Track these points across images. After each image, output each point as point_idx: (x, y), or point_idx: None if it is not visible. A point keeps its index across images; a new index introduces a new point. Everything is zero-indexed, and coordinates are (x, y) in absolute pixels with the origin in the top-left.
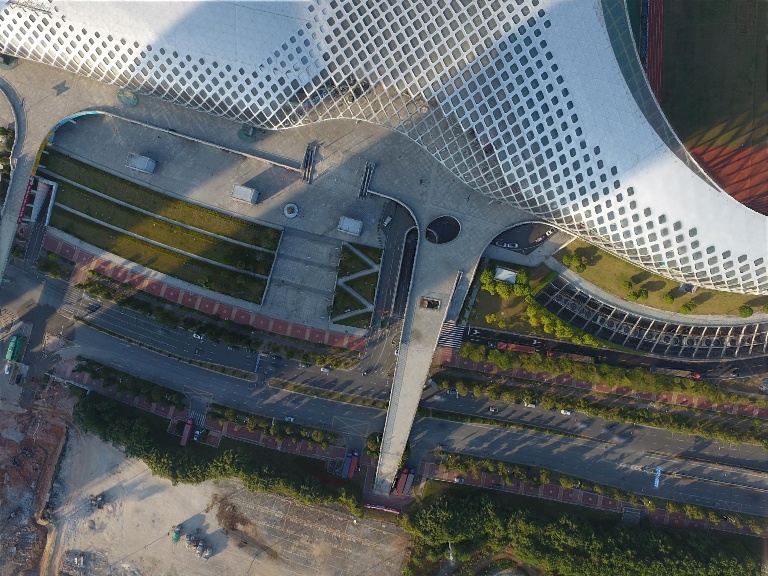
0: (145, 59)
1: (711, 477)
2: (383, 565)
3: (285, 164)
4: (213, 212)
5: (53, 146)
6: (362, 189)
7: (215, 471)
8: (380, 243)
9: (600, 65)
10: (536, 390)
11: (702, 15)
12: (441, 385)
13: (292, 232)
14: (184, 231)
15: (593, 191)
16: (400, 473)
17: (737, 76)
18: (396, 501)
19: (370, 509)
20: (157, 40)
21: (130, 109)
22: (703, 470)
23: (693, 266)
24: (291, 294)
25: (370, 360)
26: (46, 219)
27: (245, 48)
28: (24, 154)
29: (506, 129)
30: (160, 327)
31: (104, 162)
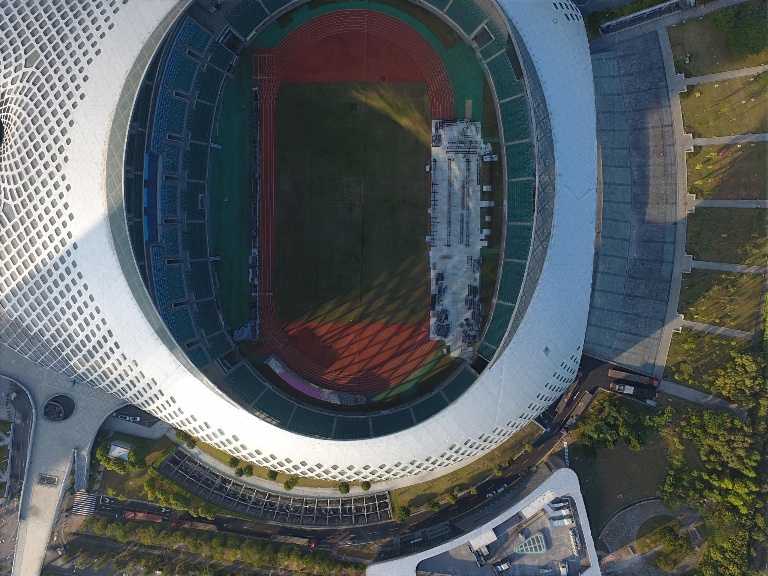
0: None
1: None
2: None
3: None
4: None
5: None
6: None
7: None
8: (8, 417)
9: (118, 289)
10: (166, 556)
11: (311, 194)
12: (62, 558)
13: None
14: None
15: (147, 395)
16: None
17: (344, 254)
18: None
19: None
20: None
21: None
22: None
23: (255, 462)
24: None
25: (8, 528)
26: None
27: None
28: None
29: (63, 336)
30: None
31: None
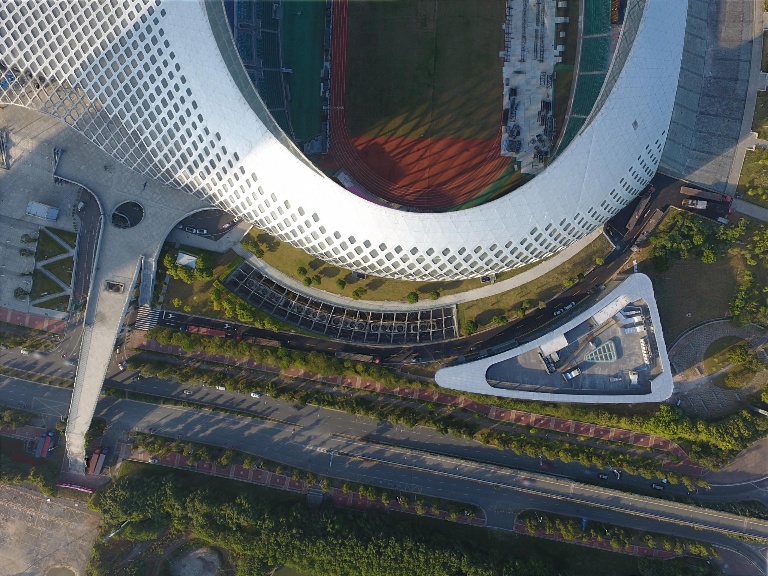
0: None
1: (392, 460)
2: (76, 543)
3: None
4: None
5: None
6: None
7: None
8: (74, 228)
9: (206, 53)
10: (228, 373)
11: (384, 8)
12: (126, 367)
13: None
14: None
15: (227, 177)
16: (91, 453)
17: (417, 68)
18: (93, 481)
19: (64, 488)
20: None
21: None
22: (385, 453)
23: (332, 251)
24: None
25: (69, 342)
26: None
27: None
28: None
29: (144, 115)
30: None
31: None
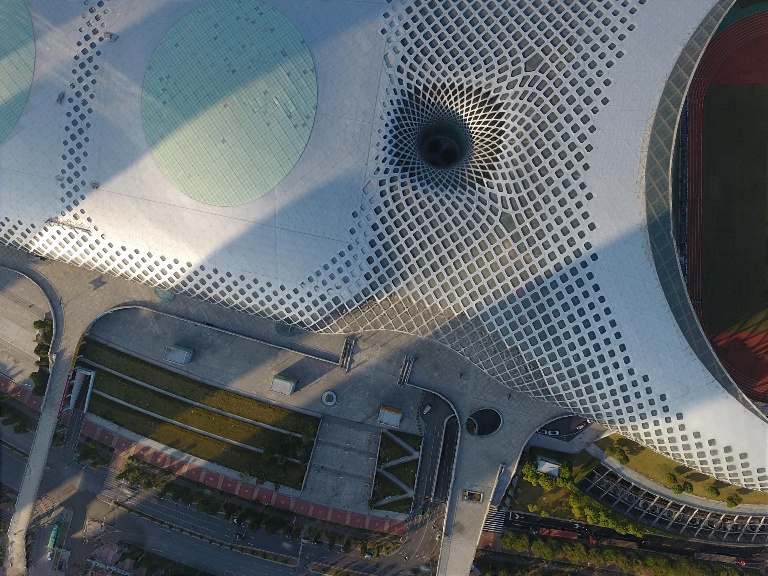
0: (185, 273)
1: None
2: None
3: (324, 358)
4: (251, 400)
5: (90, 335)
6: (401, 378)
7: None
8: (420, 431)
9: (649, 302)
10: (579, 574)
11: (742, 200)
12: None
13: (331, 419)
14: (222, 418)
15: (641, 411)
16: None
17: None
18: None
19: None
20: (197, 258)
21: (167, 303)
22: None
23: (742, 480)
24: (331, 479)
25: (411, 544)
26: (84, 406)
27: (286, 267)
28: (62, 349)
29: (551, 350)
30: (200, 512)
31: (141, 351)
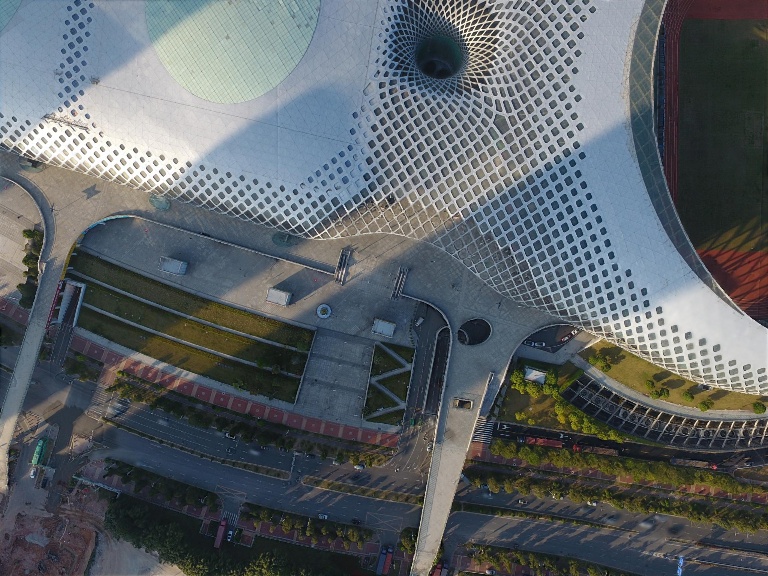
0: (184, 174)
1: (728, 562)
2: None
3: (320, 268)
4: (246, 313)
5: (81, 247)
6: (394, 291)
7: (252, 575)
8: (412, 343)
9: (632, 197)
10: (563, 482)
11: (713, 126)
12: (474, 483)
13: (325, 332)
14: (216, 332)
15: (623, 308)
16: (434, 568)
17: (746, 184)
18: None
19: None
20: (197, 157)
21: (162, 213)
22: (721, 556)
23: (715, 375)
24: (324, 392)
25: (403, 456)
26: (73, 320)
27: (286, 167)
28: (53, 258)
29: (541, 249)
30: (192, 427)
31: (134, 263)
